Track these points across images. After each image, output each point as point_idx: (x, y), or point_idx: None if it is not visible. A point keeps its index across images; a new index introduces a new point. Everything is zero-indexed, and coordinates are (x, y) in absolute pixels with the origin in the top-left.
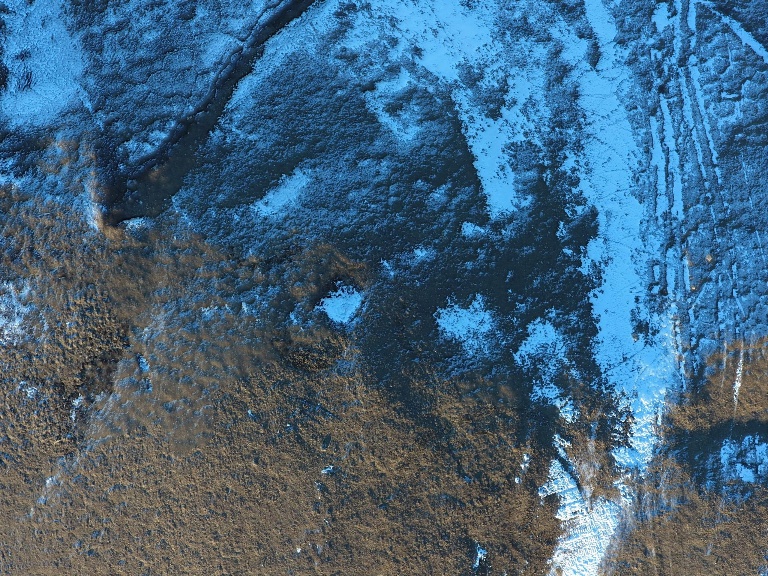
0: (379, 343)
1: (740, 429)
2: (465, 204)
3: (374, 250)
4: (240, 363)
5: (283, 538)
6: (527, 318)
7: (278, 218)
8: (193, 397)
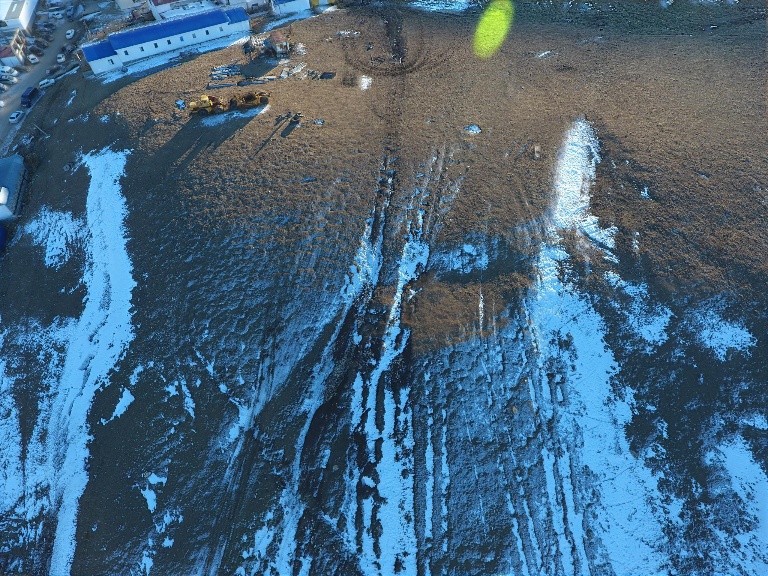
0: None
1: (475, 277)
2: None
3: None
4: None
5: None
6: (671, 344)
7: None
8: None
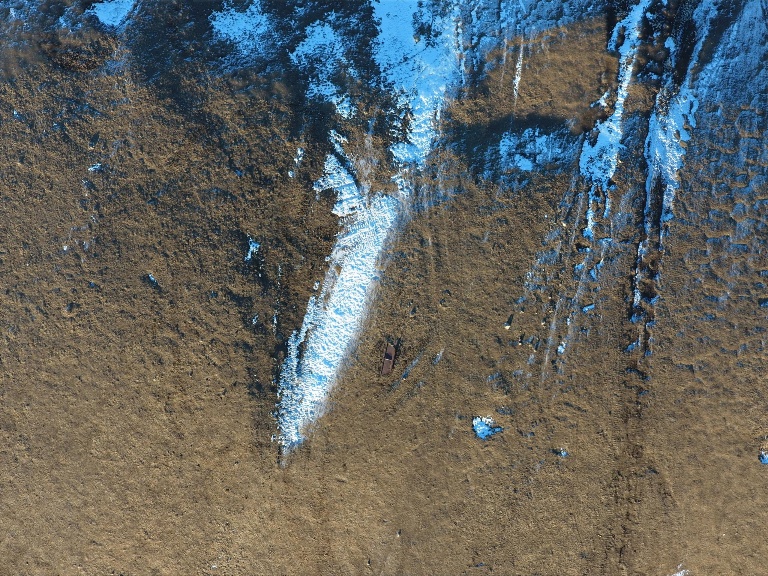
0: (150, 43)
1: (520, 122)
2: None
3: None
4: (6, 65)
5: (49, 237)
6: (306, 21)
7: None
8: None
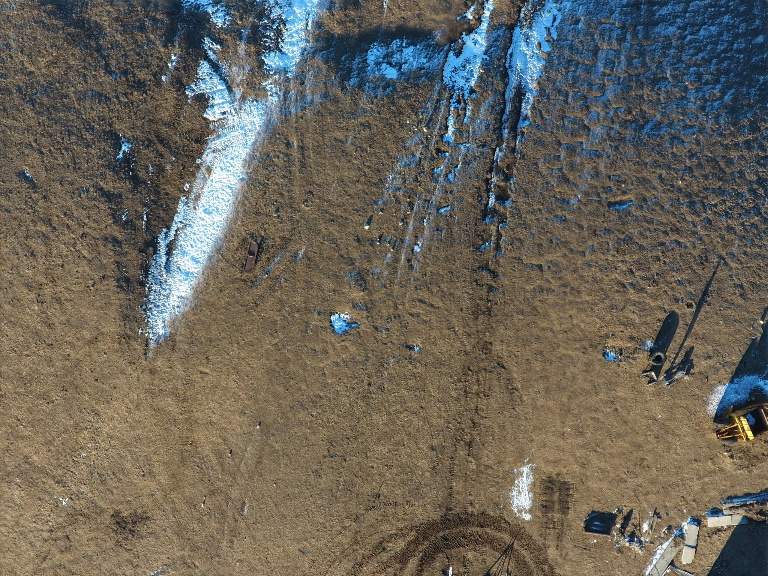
0: None
1: (388, 33)
2: None
3: None
4: None
5: None
6: None
7: None
8: None
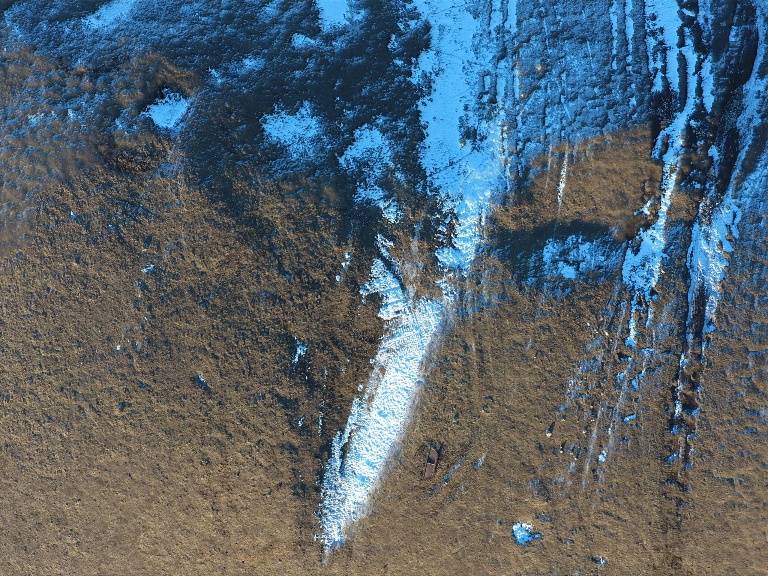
0: (203, 146)
1: (564, 229)
2: (296, 17)
3: (202, 59)
4: (64, 166)
5: (103, 336)
6: (354, 124)
7: (108, 30)
8: (16, 200)
